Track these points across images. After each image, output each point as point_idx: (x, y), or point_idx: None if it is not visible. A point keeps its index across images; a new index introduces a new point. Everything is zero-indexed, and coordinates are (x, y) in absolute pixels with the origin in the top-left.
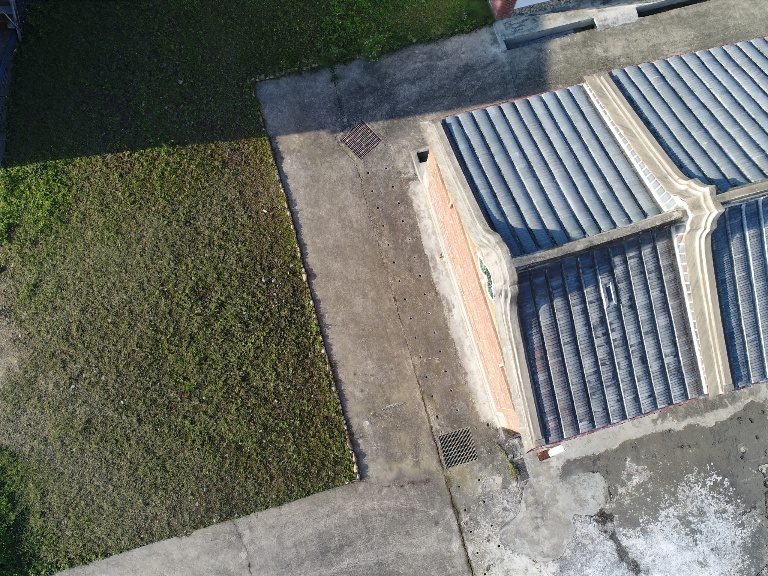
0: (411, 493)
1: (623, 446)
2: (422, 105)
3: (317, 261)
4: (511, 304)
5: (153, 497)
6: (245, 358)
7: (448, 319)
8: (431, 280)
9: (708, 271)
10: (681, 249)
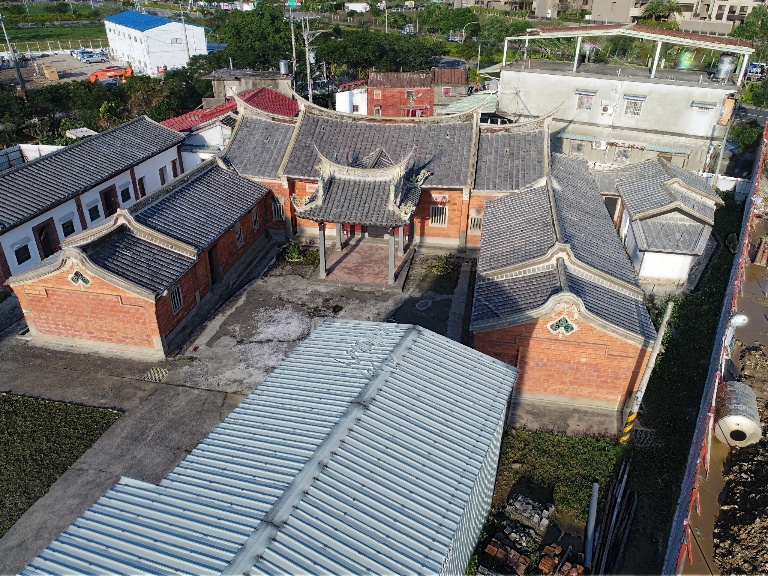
0: (154, 397)
1: (221, 327)
2: (3, 327)
3: (5, 388)
4: (90, 261)
5: (4, 500)
6: (2, 430)
7: (100, 355)
8: (76, 354)
9: (148, 229)
10: (136, 234)
